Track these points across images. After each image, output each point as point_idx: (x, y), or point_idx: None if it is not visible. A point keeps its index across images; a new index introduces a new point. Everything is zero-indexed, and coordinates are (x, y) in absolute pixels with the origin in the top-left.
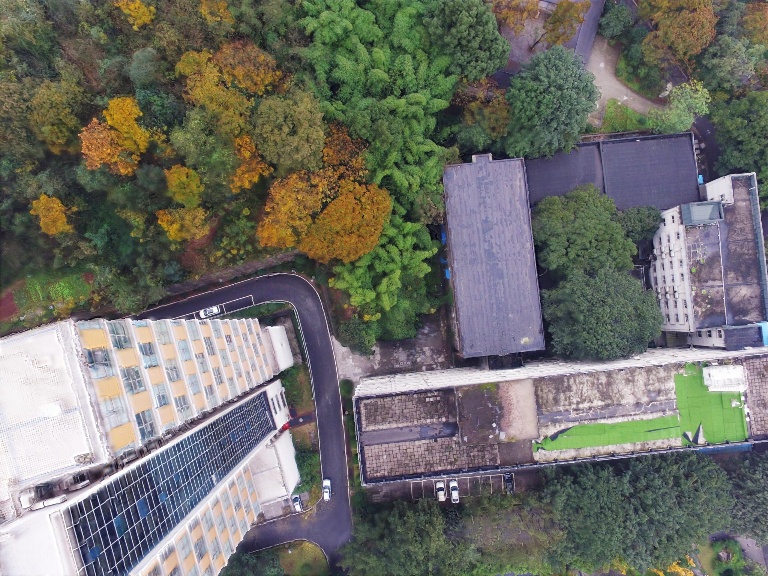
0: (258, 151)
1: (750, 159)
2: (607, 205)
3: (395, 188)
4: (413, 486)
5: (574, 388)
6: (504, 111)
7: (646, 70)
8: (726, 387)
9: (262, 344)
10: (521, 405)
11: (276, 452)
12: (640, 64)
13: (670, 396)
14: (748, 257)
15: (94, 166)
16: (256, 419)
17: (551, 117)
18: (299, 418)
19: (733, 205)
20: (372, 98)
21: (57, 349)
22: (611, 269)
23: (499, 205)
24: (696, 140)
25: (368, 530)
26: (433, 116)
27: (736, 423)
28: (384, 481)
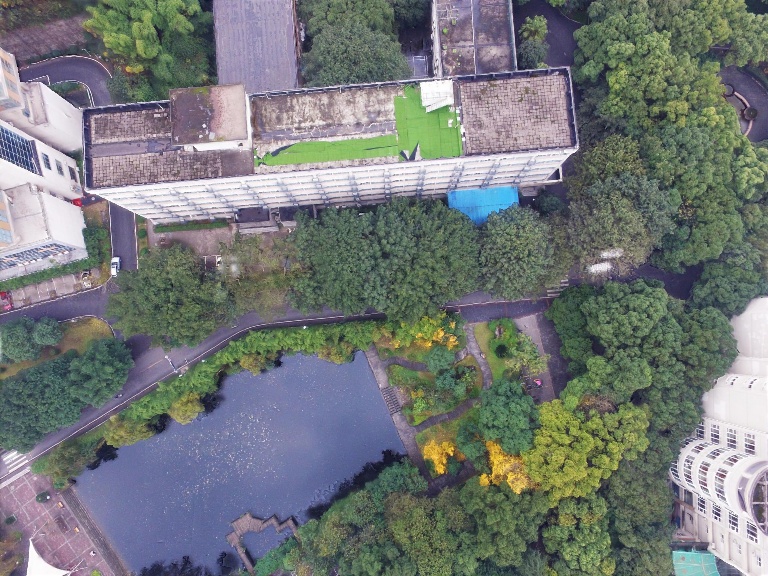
0: None
1: None
2: None
3: None
4: None
5: (297, 108)
6: None
7: None
8: (438, 104)
9: (14, 75)
10: (231, 108)
11: (40, 197)
12: None
13: (389, 117)
14: (499, 19)
15: None
16: (4, 145)
17: None
18: (91, 197)
19: None
20: None
21: None
22: None
23: None
24: None
25: None
26: None
27: (452, 143)
28: (106, 186)
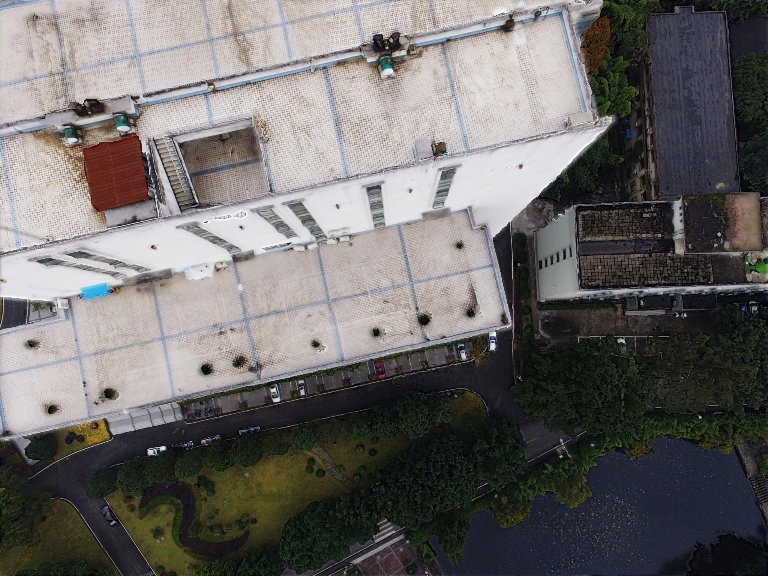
0: None
1: None
2: None
3: None
4: (580, 341)
5: None
6: None
7: None
8: None
9: None
10: (746, 217)
11: None
12: None
13: None
14: None
15: None
16: None
17: None
18: None
19: None
20: None
21: None
22: None
23: (700, 54)
24: None
25: (551, 364)
26: None
27: None
28: (601, 288)
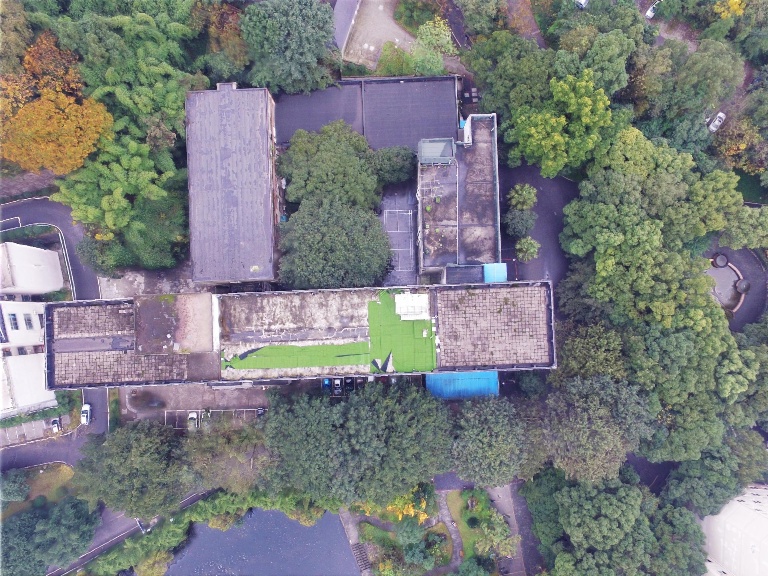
0: None
1: (500, 102)
2: (353, 141)
3: (128, 109)
4: (167, 415)
5: (267, 309)
6: (235, 36)
7: (418, 13)
8: (413, 315)
9: None
10: (197, 318)
11: (5, 364)
12: (415, 7)
13: (363, 323)
14: (485, 199)
15: None
16: None
17: (284, 45)
18: None
19: (474, 146)
20: (105, 17)
21: None
22: (340, 201)
23: (239, 133)
24: (475, 88)
25: (95, 448)
26: (174, 41)
27: (426, 354)
28: (67, 387)
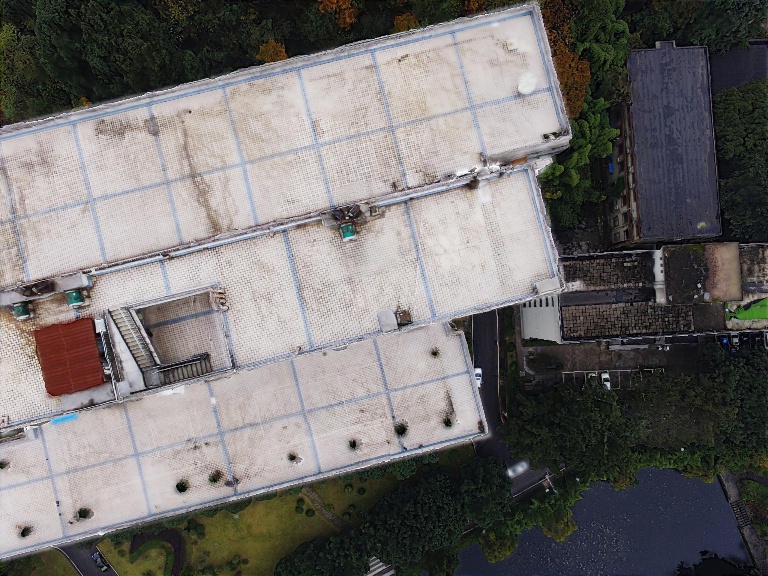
0: (484, 4)
1: None
2: None
3: None
4: (565, 376)
5: None
6: None
7: None
8: None
9: None
10: (726, 268)
11: None
12: None
13: None
14: None
15: (330, 8)
16: None
17: (744, 1)
18: None
19: None
20: None
21: (527, 34)
22: None
23: (681, 91)
24: None
25: (535, 406)
26: None
27: None
28: (583, 340)
